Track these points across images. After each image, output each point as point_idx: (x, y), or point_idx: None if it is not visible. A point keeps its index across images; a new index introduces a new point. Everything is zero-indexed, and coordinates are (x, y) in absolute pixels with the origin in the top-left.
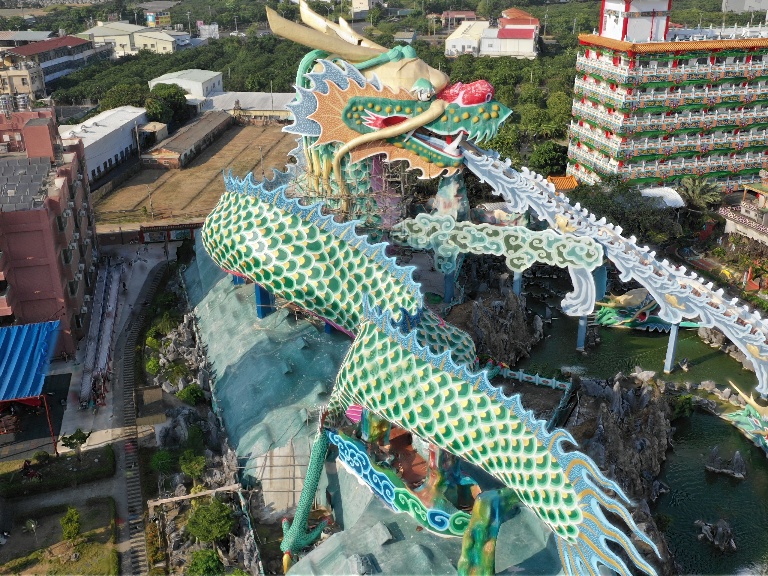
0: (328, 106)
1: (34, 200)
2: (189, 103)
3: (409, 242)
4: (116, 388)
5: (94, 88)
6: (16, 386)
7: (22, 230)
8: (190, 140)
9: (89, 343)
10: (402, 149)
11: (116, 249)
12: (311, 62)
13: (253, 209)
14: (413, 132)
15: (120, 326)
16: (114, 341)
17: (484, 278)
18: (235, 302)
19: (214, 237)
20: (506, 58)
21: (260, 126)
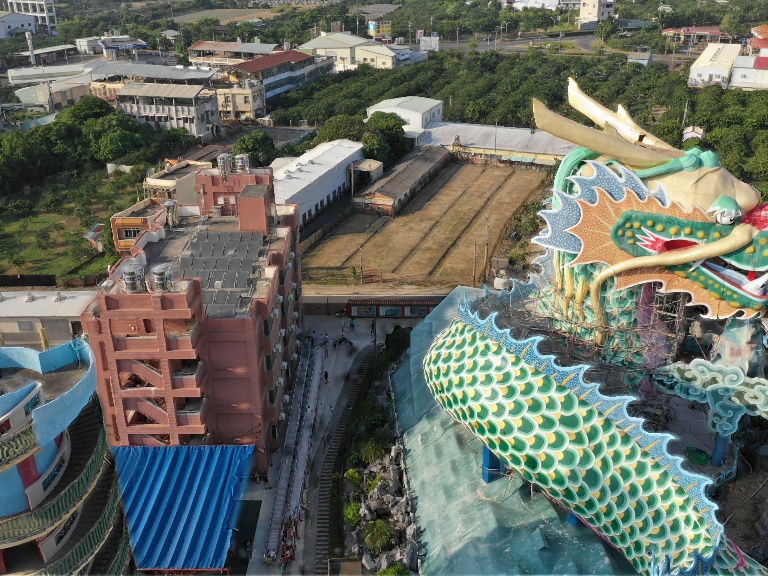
0: (594, 219)
1: (241, 298)
2: (407, 136)
3: (677, 390)
4: (308, 534)
5: (312, 110)
6: (199, 546)
7: (225, 339)
8: (405, 182)
9: (283, 460)
10: (684, 279)
11: (321, 322)
12: (578, 162)
13: (494, 358)
14: (703, 260)
15: (318, 436)
16: (310, 459)
17: (760, 426)
18: (454, 447)
19: (441, 380)
20: (762, 93)
21: (479, 165)
